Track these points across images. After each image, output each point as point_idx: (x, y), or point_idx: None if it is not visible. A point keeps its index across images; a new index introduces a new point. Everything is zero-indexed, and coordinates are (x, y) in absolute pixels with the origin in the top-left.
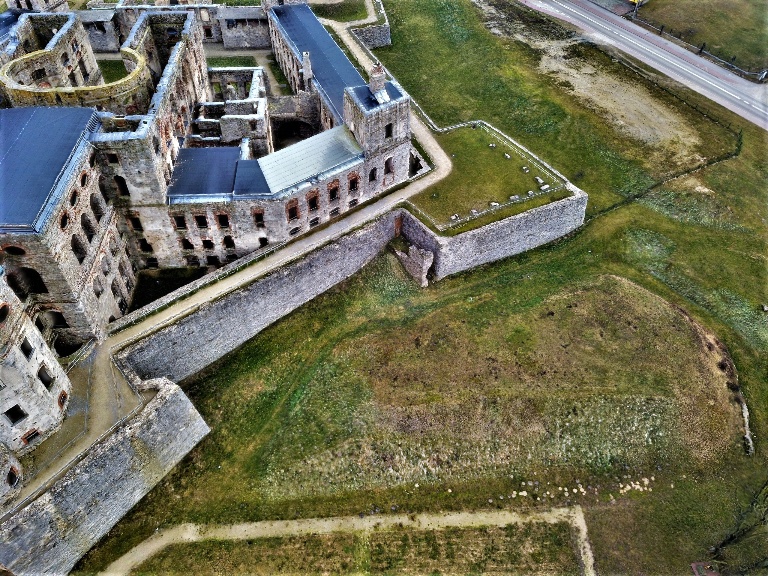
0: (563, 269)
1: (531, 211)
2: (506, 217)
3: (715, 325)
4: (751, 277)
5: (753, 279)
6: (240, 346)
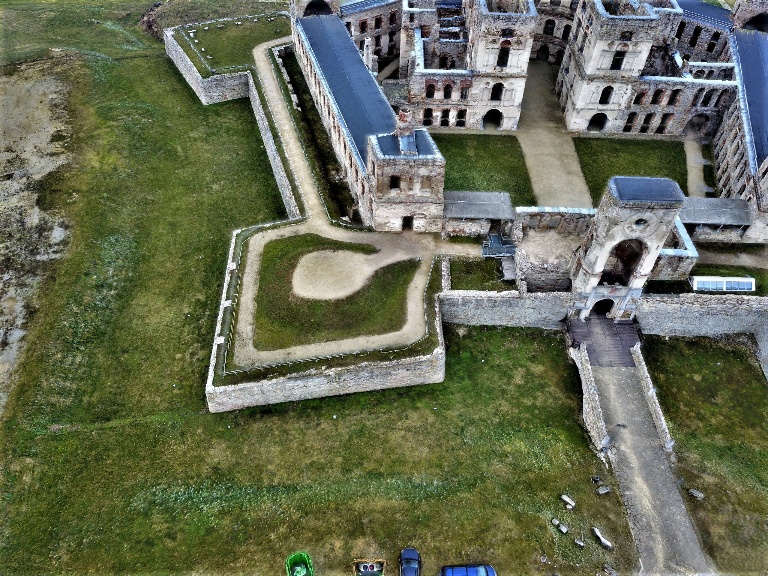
0: None
1: (215, 20)
2: None
3: (131, 28)
4: (84, 32)
5: (84, 31)
6: None
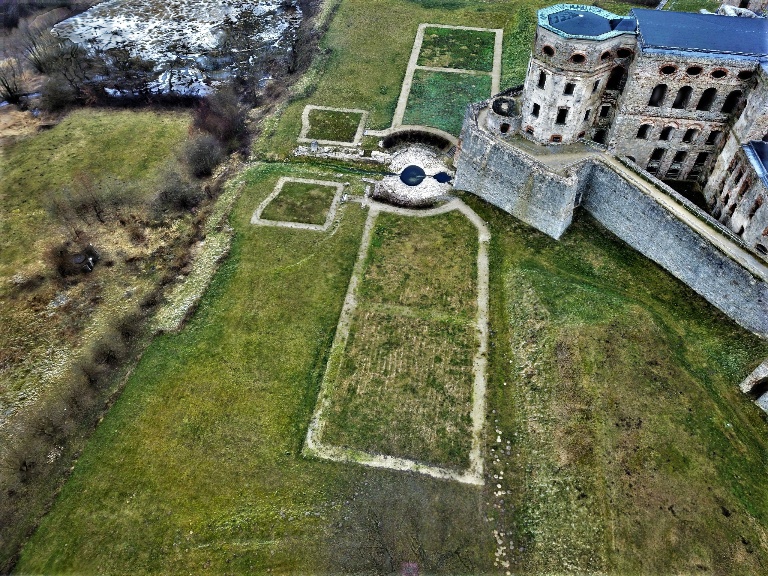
0: None
1: None
2: None
3: None
4: None
5: None
6: (634, 249)
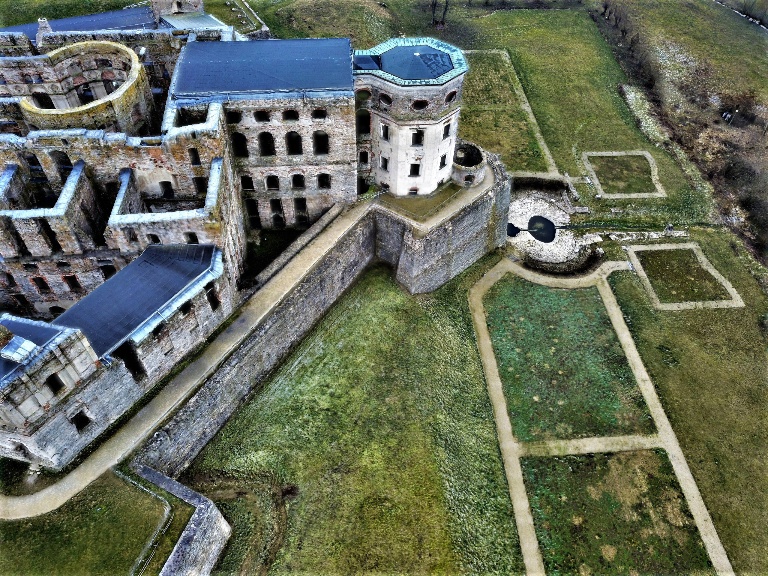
0: (269, 24)
1: (243, 0)
2: (247, 8)
3: None
4: None
5: None
6: None
